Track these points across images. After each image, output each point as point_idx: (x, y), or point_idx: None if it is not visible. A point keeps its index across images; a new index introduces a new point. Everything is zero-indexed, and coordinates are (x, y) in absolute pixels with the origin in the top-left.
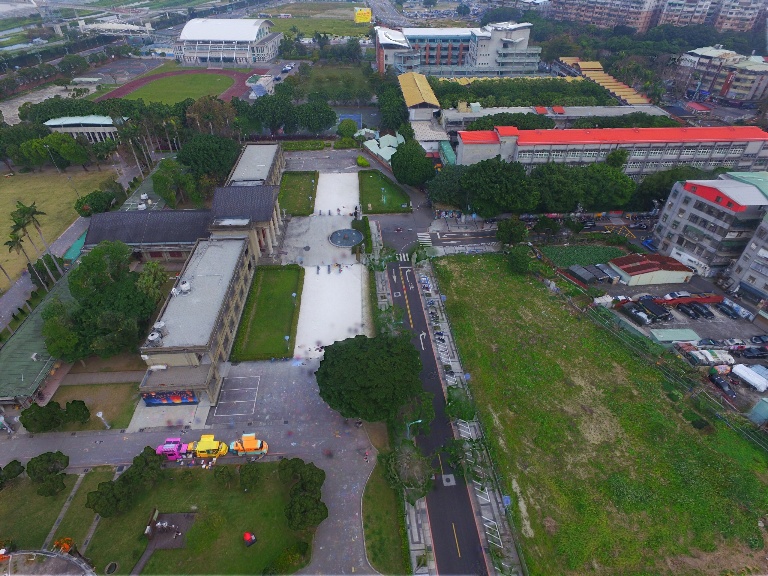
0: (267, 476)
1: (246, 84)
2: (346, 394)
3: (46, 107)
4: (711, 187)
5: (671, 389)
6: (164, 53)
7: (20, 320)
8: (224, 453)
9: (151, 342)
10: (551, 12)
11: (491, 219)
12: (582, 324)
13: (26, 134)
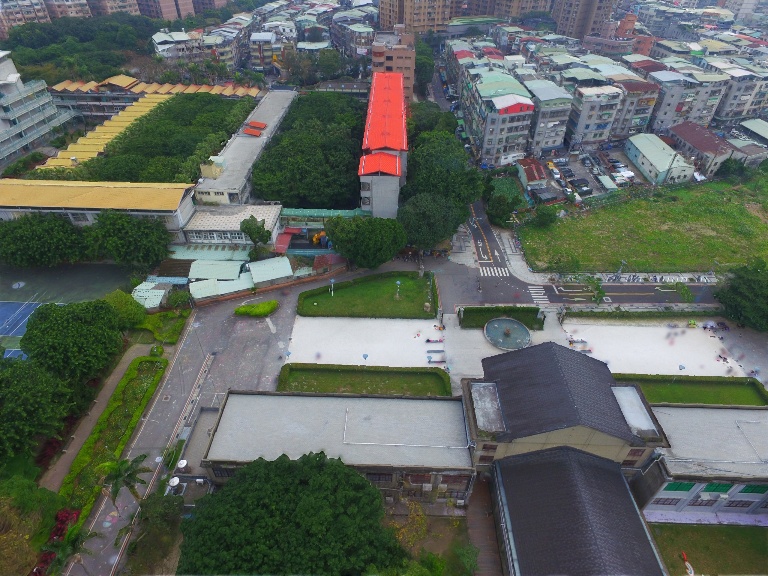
0: None
1: None
2: None
3: None
4: (516, 104)
5: None
6: None
7: None
8: None
9: None
10: None
11: None
12: (601, 213)
13: None
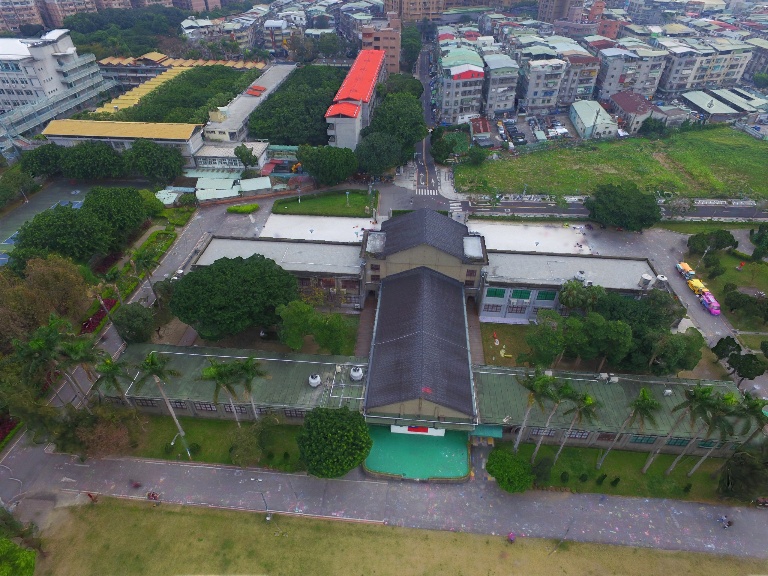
0: None
1: None
2: None
3: None
4: (467, 71)
5: None
6: None
7: None
8: None
9: None
10: None
11: None
12: (528, 157)
13: None
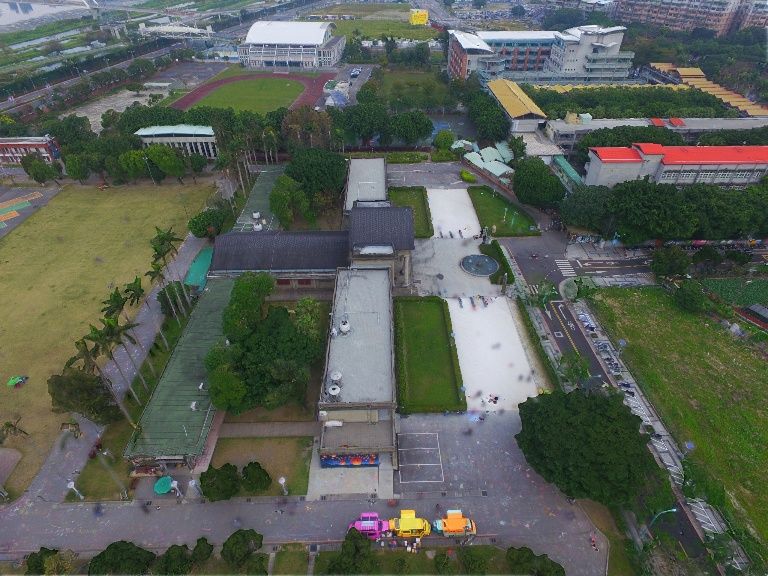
0: (486, 565)
1: (324, 90)
2: (574, 470)
3: (136, 116)
4: None
5: None
6: (227, 57)
7: (156, 356)
8: (428, 532)
9: (331, 397)
10: (618, 13)
11: (633, 246)
12: None
13: (121, 145)
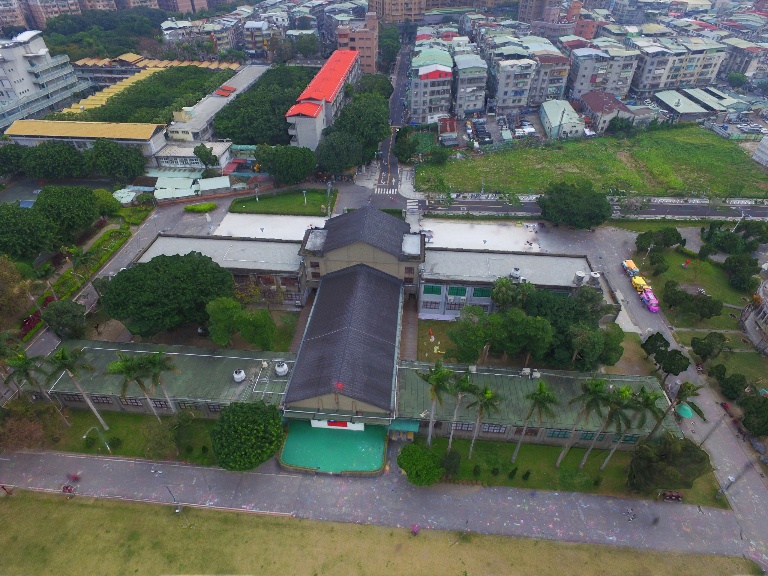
0: None
1: None
2: None
3: None
4: (434, 71)
5: (539, 148)
6: None
7: None
8: None
9: None
10: None
11: None
12: (492, 157)
13: None
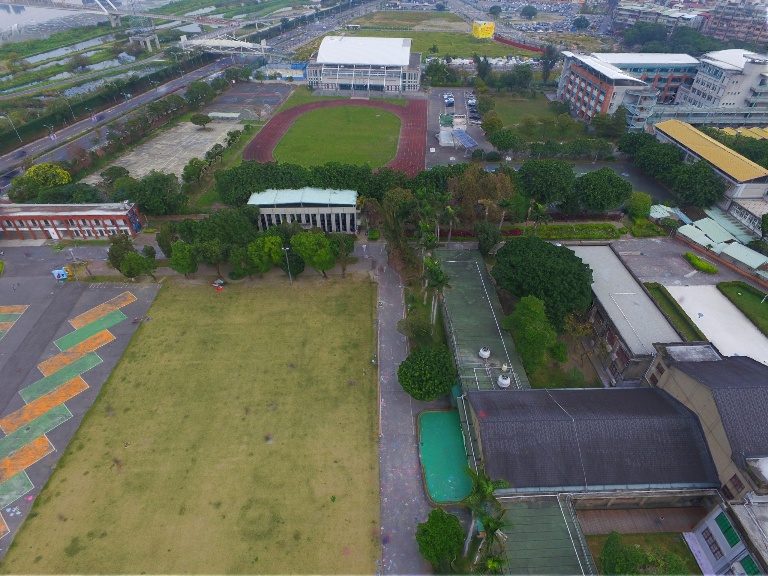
0: None
1: (441, 128)
2: None
3: (246, 176)
4: None
5: None
6: (292, 77)
7: None
8: None
9: None
10: (709, 29)
11: None
12: None
13: (241, 224)
